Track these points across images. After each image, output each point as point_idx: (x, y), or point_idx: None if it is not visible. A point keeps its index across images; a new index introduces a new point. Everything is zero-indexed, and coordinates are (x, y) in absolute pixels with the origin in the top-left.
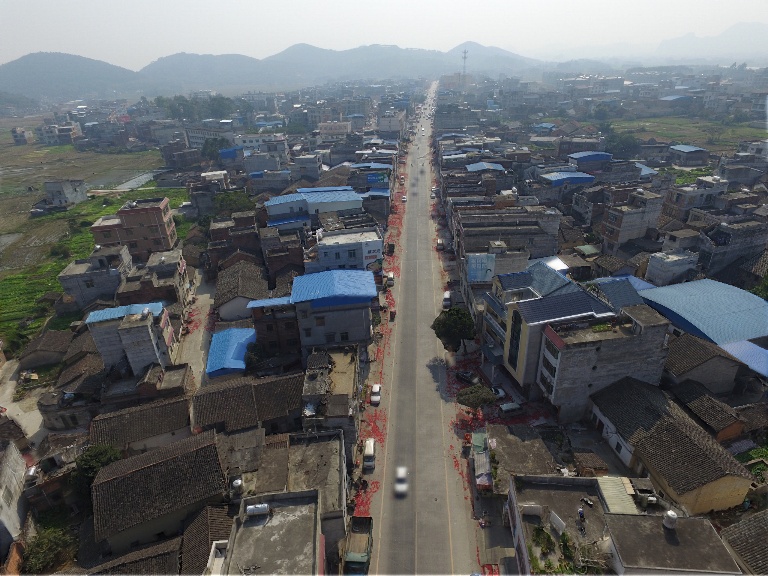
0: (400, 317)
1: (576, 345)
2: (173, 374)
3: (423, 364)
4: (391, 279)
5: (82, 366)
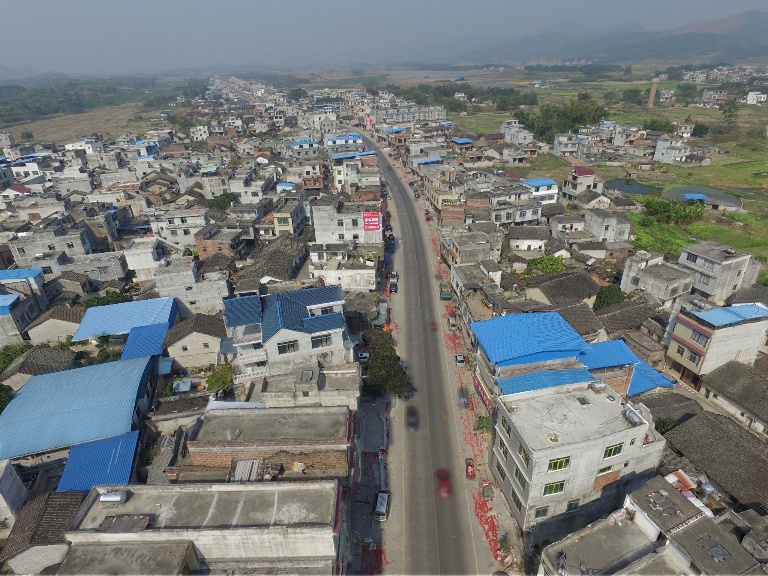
0: (458, 468)
1: (312, 280)
2: (653, 346)
3: (420, 391)
4: None
5: (767, 356)
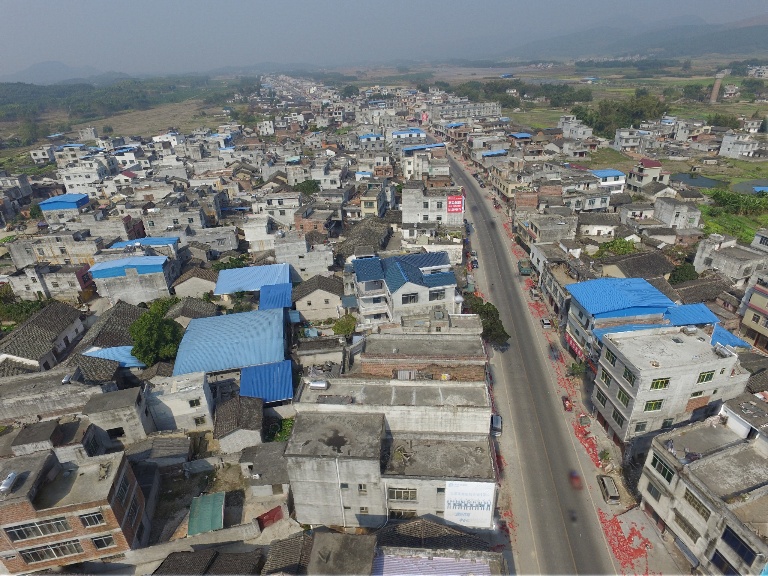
0: (556, 403)
1: (416, 249)
2: (728, 316)
3: (513, 346)
4: (605, 476)
5: None
